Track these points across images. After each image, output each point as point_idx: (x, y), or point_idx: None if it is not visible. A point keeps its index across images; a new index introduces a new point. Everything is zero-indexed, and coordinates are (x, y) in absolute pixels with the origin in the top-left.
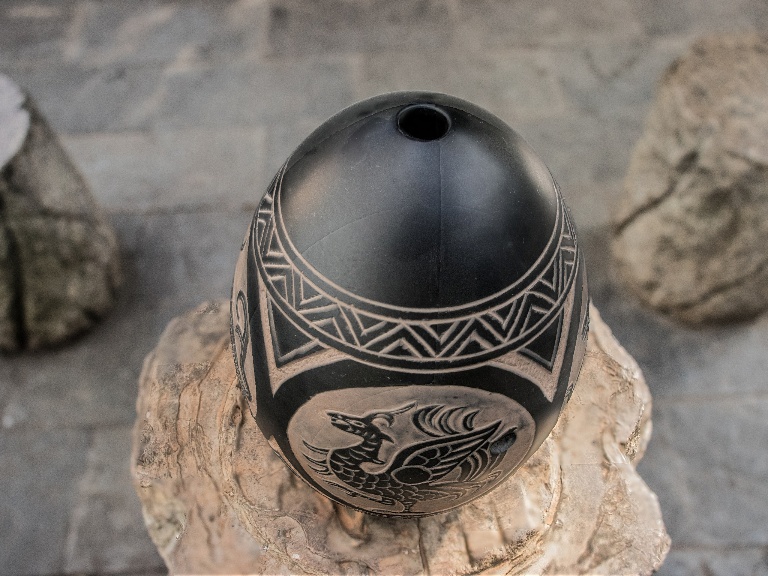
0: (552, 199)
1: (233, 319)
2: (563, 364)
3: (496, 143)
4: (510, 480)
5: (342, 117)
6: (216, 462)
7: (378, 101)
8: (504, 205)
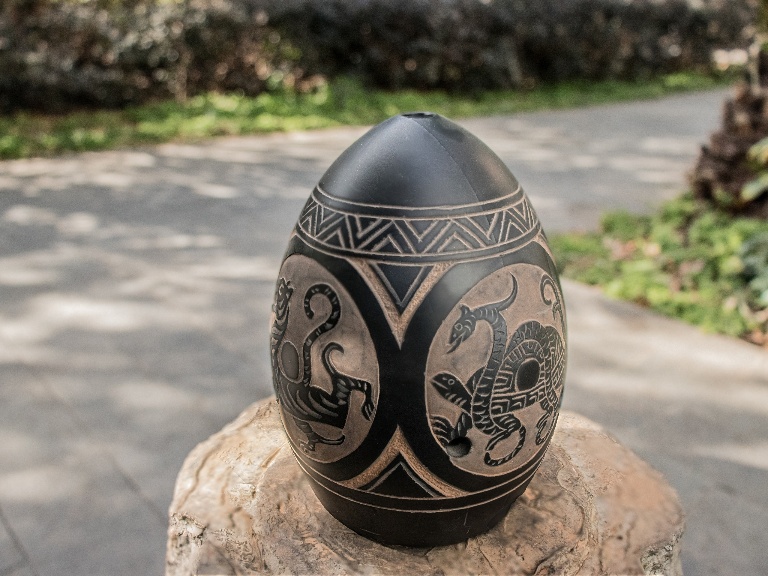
0: None
1: (549, 325)
2: None
3: None
4: None
5: (429, 156)
6: (588, 568)
7: (409, 137)
8: None
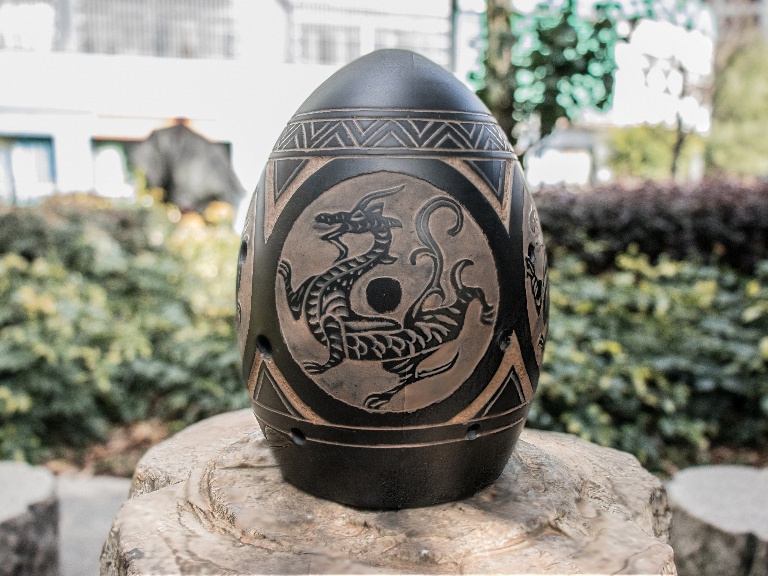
0: (378, 103)
1: None
2: (284, 211)
3: (391, 61)
4: (298, 510)
5: None
6: None
7: None
8: (344, 75)
